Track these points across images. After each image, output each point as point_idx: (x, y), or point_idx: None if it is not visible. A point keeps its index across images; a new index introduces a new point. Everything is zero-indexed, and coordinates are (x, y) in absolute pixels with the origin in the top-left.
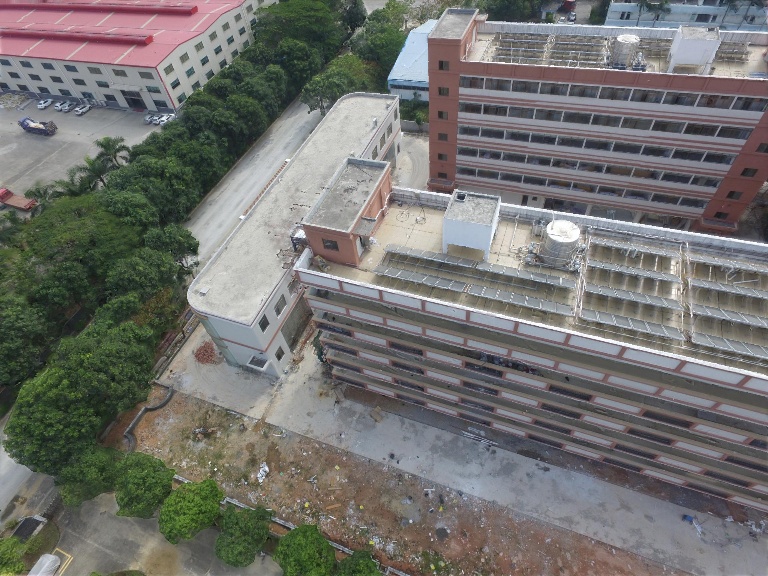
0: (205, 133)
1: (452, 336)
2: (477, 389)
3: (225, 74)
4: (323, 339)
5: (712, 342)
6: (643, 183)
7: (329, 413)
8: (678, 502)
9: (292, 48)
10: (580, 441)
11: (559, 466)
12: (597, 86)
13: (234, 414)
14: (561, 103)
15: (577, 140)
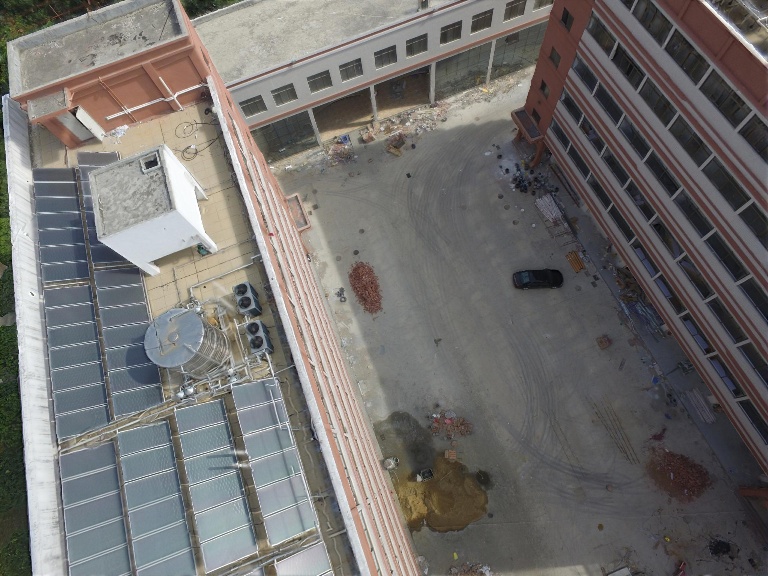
0: None
1: None
2: None
3: None
4: None
5: None
6: (745, 371)
7: None
8: None
9: None
10: None
11: None
12: None
13: None
14: (718, 135)
15: (703, 220)
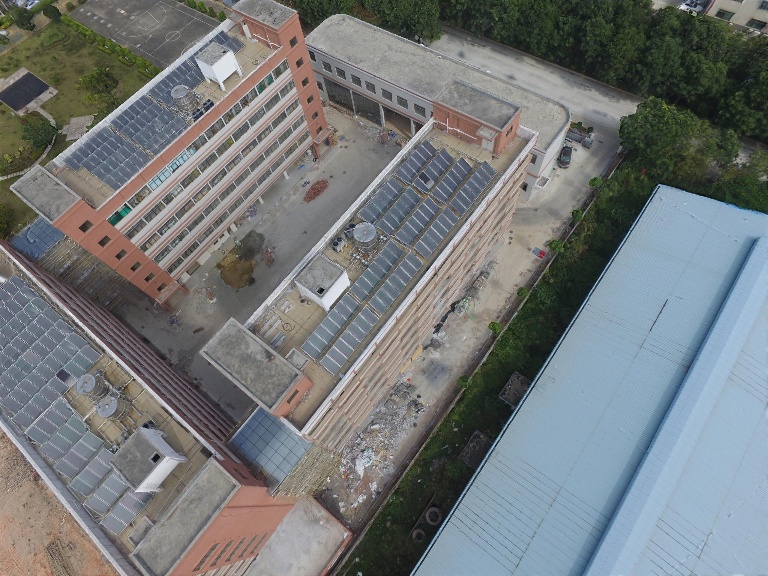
0: (570, 19)
1: None
2: None
3: None
4: None
5: (103, 133)
6: None
7: None
8: None
9: (766, 83)
10: None
11: None
12: None
13: None
14: None
15: None
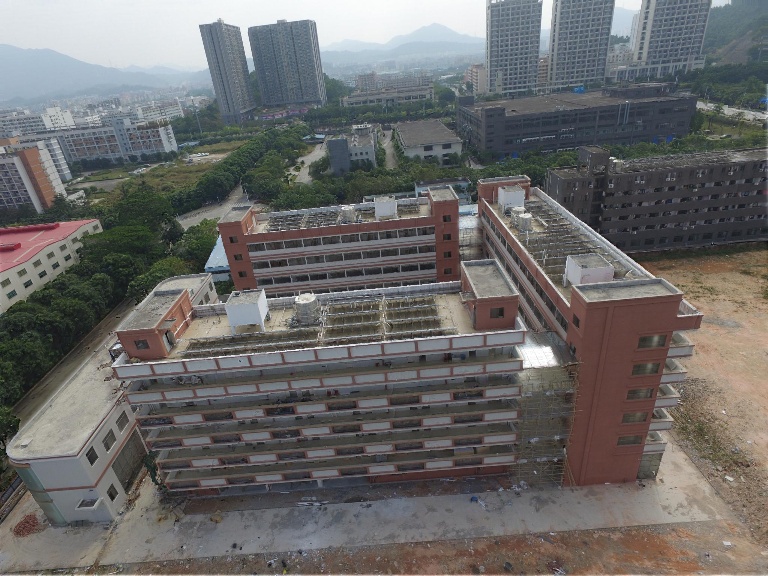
0: (28, 332)
1: (246, 386)
2: (284, 437)
3: (50, 286)
4: (149, 440)
5: None
6: None
7: (169, 533)
8: (466, 492)
9: (117, 260)
10: (378, 461)
11: (378, 500)
12: (338, 236)
13: (61, 571)
14: (320, 250)
15: (340, 273)
